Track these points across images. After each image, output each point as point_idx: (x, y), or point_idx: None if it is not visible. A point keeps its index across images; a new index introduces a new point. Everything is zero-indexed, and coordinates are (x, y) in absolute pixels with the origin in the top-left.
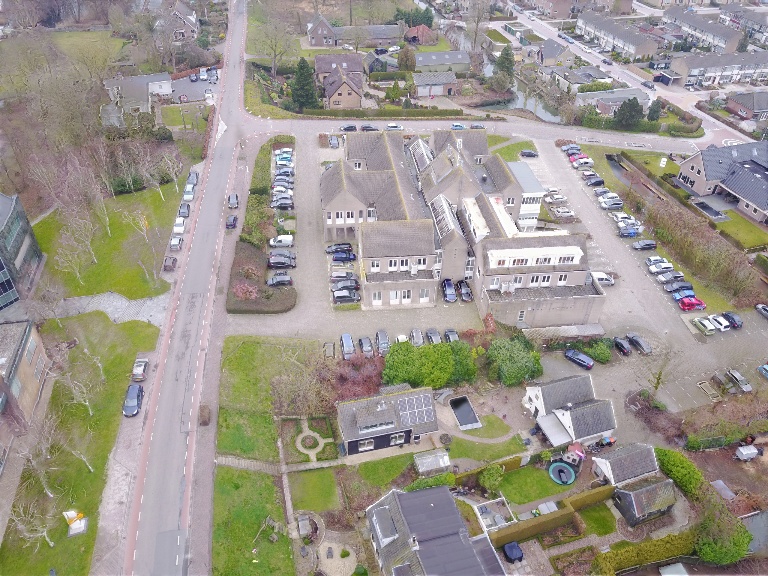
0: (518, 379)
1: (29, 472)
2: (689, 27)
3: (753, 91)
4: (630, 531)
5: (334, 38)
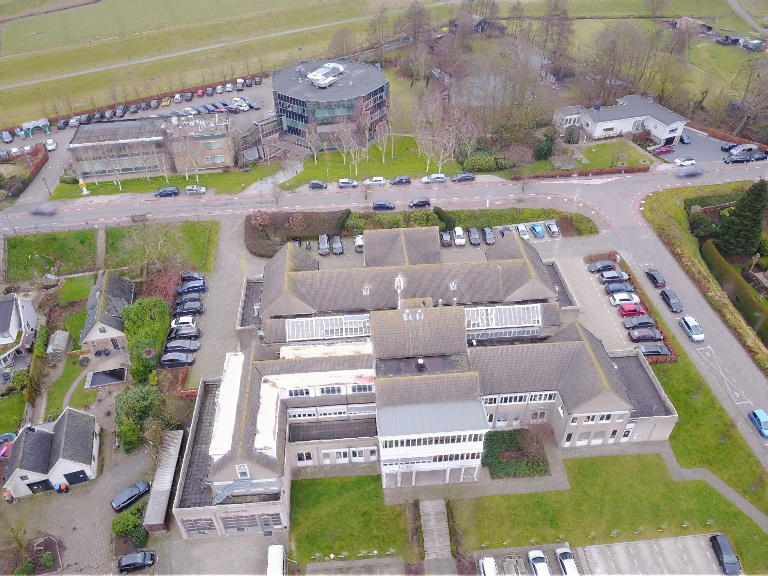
0: None
1: None
2: None
3: None
4: None
5: None
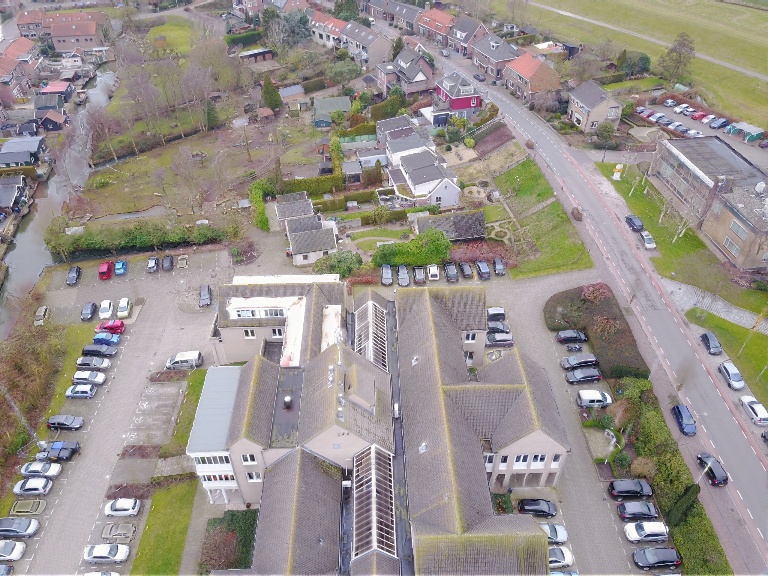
0: None
1: (674, 210)
2: None
3: None
4: None
5: None
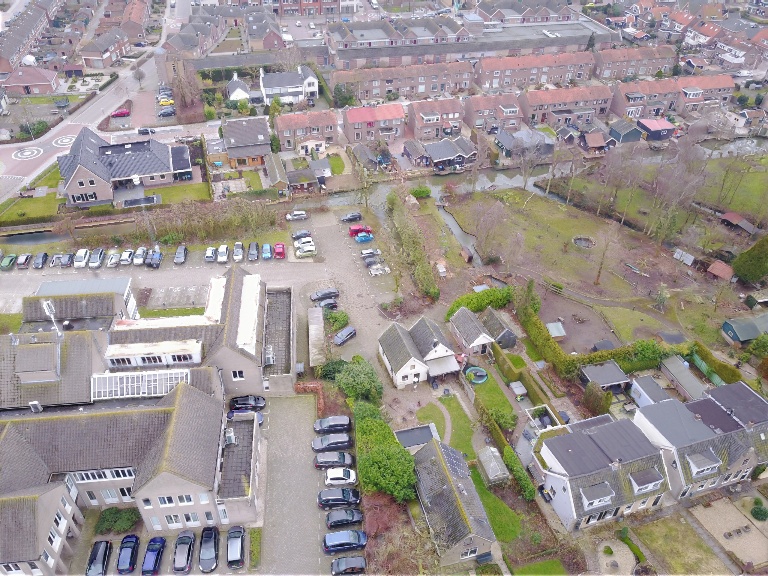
0: None
1: None
2: None
3: None
4: (517, 348)
5: None
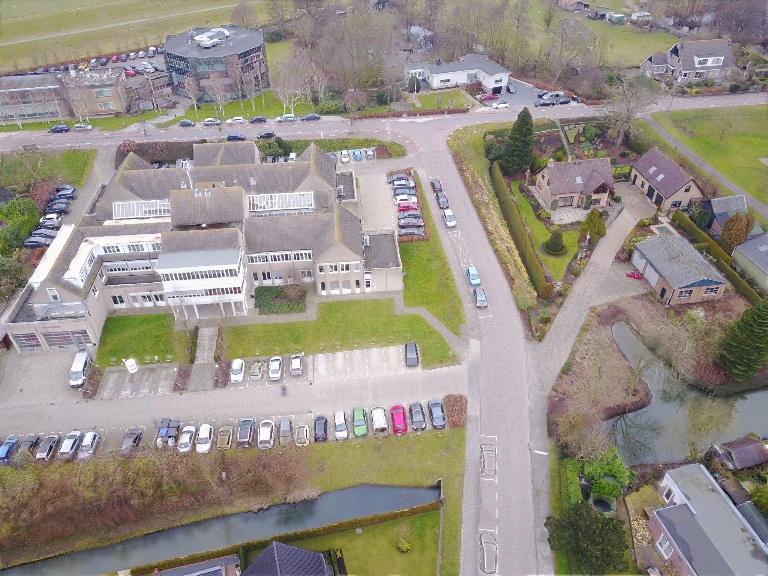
0: None
1: None
2: None
3: None
4: None
5: None
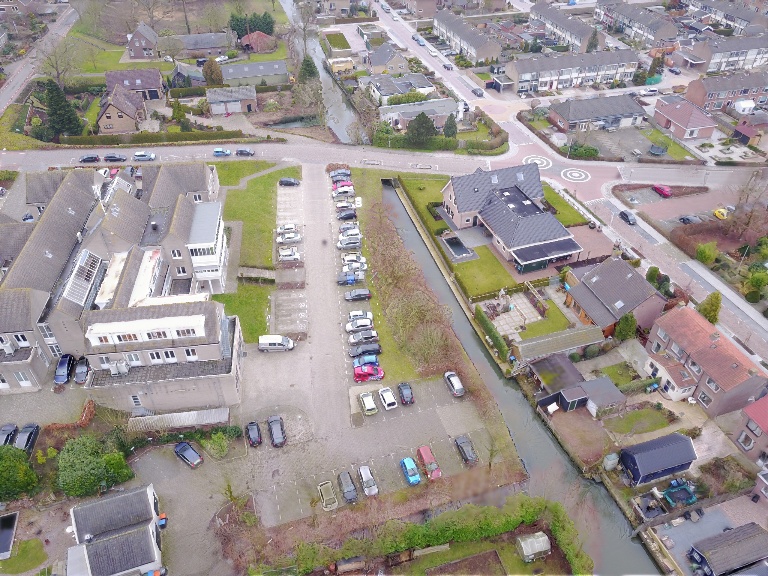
0: (90, 488)
1: None
2: (551, 24)
3: (591, 96)
4: None
5: (156, 49)
